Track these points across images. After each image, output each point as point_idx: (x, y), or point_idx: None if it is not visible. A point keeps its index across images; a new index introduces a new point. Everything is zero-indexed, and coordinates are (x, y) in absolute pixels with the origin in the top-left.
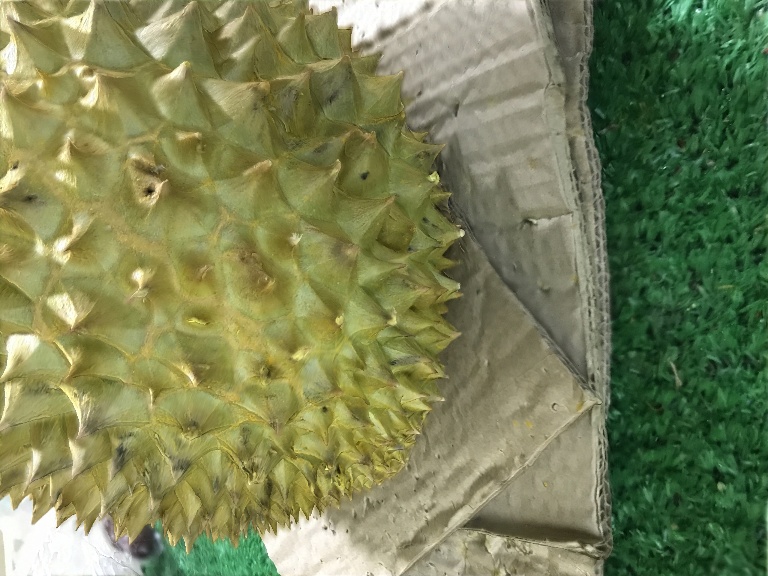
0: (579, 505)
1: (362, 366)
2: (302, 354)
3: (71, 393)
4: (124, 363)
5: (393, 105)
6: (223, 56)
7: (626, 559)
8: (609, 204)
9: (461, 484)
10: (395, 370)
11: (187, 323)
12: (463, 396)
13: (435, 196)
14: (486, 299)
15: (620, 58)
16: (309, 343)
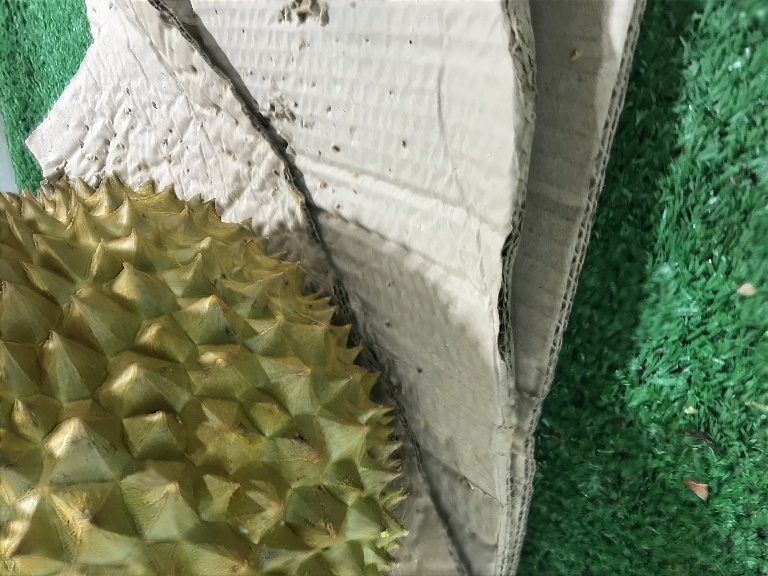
0: None
1: None
2: None
3: None
4: None
5: (356, 450)
6: (198, 460)
7: None
8: (537, 489)
9: None
10: None
11: None
12: None
13: (386, 499)
14: (423, 522)
15: (573, 395)
16: None
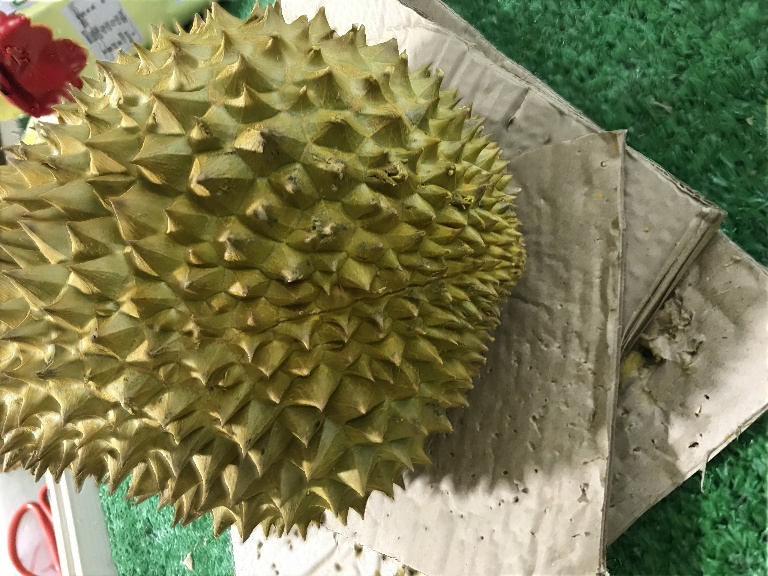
0: (678, 209)
1: (436, 99)
2: (390, 68)
3: (245, 134)
4: (277, 95)
5: None
6: None
7: (756, 243)
8: (550, 85)
9: (592, 304)
10: (465, 134)
11: (309, 62)
12: (544, 240)
13: None
14: (514, 172)
15: None
16: (393, 89)
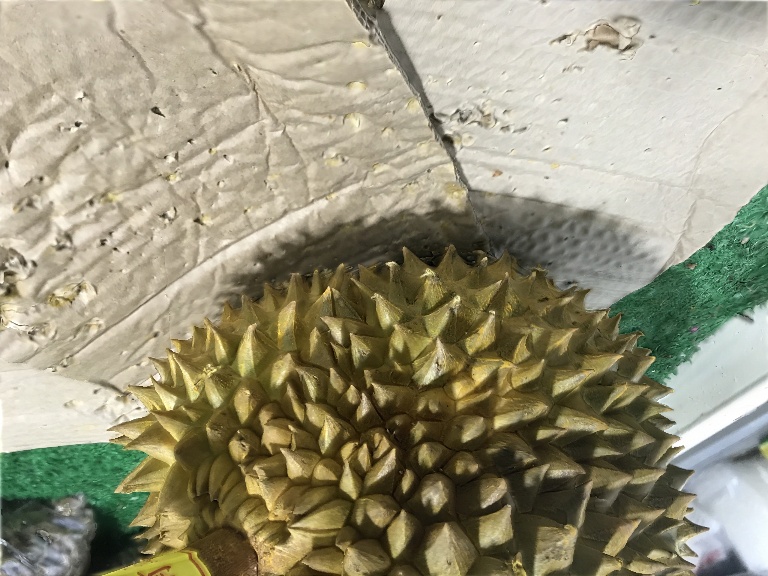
0: None
1: None
2: None
3: None
4: None
5: None
6: None
7: None
8: None
9: None
10: None
11: None
12: None
13: None
14: None
15: None
16: None
